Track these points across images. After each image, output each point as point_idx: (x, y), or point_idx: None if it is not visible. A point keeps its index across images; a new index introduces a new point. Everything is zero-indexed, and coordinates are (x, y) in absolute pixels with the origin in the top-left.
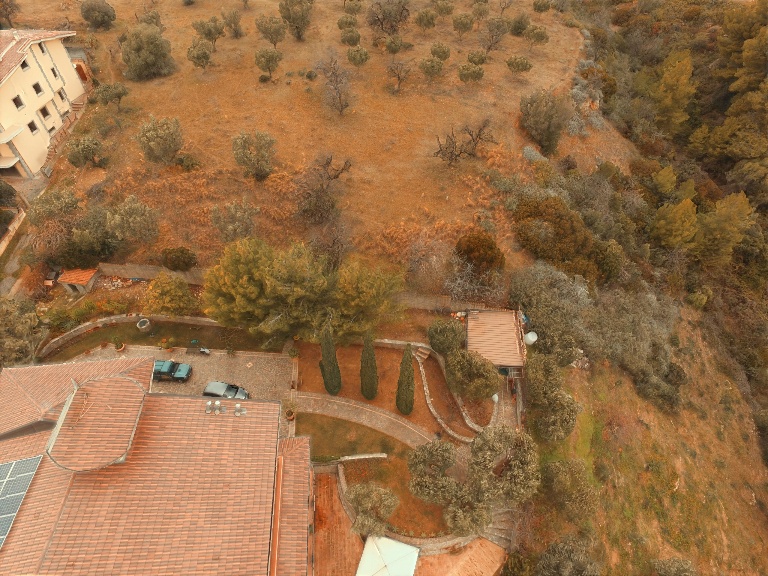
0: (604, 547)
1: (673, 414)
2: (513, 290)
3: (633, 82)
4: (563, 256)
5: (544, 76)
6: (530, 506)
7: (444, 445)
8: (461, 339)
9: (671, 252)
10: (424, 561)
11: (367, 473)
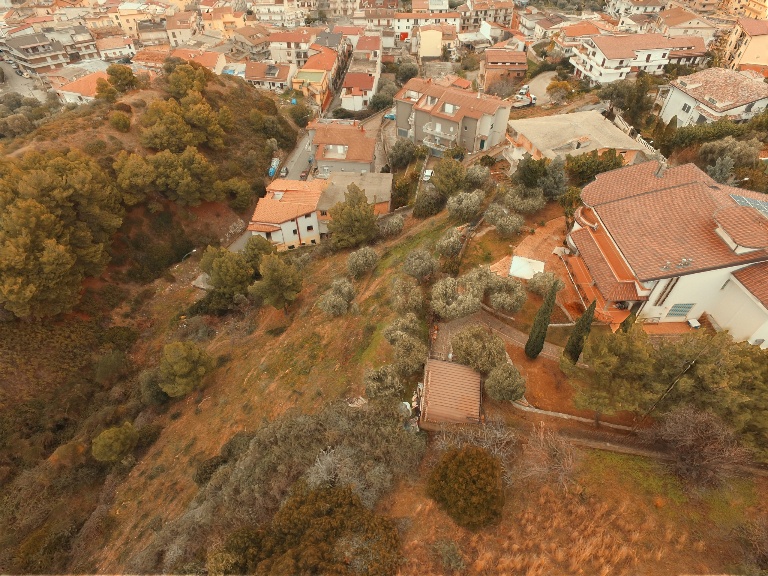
0: None
1: None
2: None
3: None
4: None
5: None
6: None
7: (502, 299)
8: None
9: None
10: None
11: (551, 316)
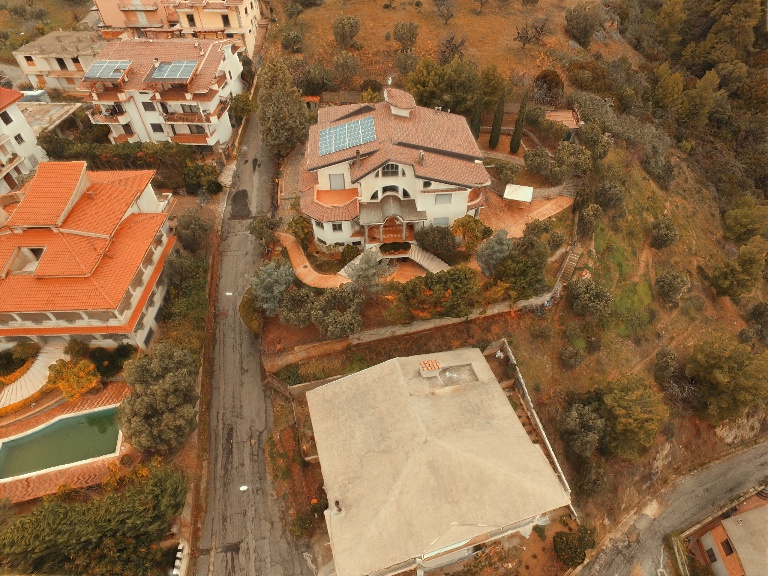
0: (624, 208)
1: (665, 190)
2: (570, 101)
3: (641, 15)
4: (598, 90)
5: None
6: (588, 172)
7: (542, 149)
8: (544, 117)
9: (666, 110)
10: (533, 202)
11: None
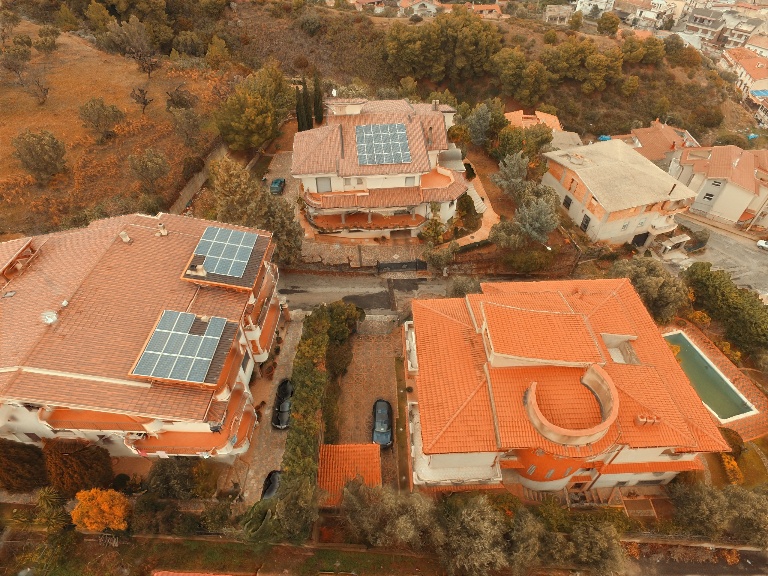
0: None
1: None
2: None
3: None
4: None
5: (58, 39)
6: (367, 94)
7: None
8: None
9: None
10: None
11: None
